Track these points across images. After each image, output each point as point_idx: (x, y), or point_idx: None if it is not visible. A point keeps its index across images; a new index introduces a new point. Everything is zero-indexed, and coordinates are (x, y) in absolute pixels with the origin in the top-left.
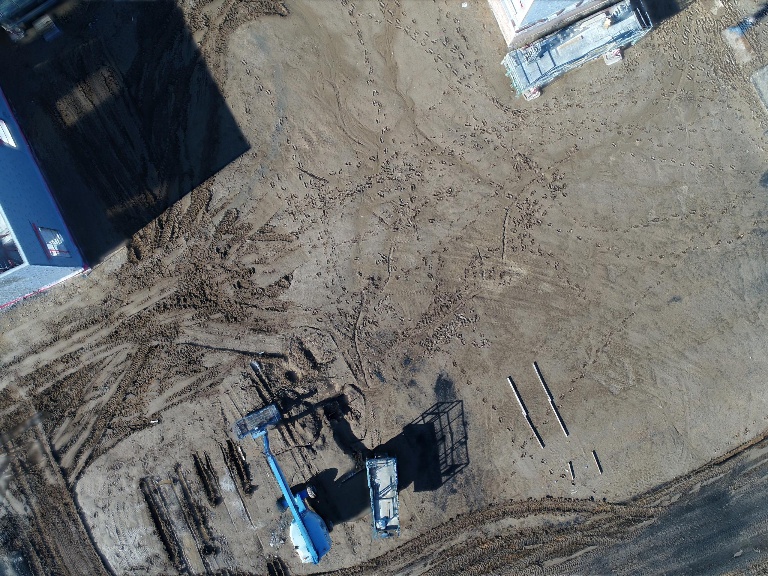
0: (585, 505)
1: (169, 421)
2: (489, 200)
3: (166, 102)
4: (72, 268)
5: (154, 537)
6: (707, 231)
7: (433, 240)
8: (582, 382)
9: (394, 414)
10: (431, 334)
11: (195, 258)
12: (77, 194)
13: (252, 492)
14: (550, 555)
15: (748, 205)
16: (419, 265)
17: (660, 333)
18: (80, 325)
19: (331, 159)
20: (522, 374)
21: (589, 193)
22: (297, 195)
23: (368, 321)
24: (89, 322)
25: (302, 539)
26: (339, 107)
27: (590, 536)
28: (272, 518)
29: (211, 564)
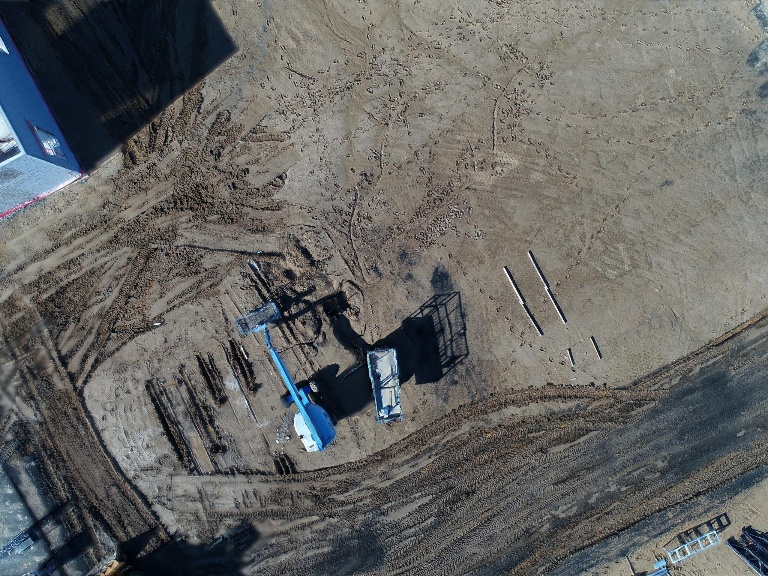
0: (586, 391)
1: (171, 323)
2: (477, 92)
3: (154, 8)
4: (69, 171)
5: (162, 438)
6: (696, 113)
7: (423, 134)
8: (578, 269)
9: (392, 308)
10: (426, 227)
11: (190, 161)
12: (71, 103)
13: (256, 390)
14: (553, 442)
15: (736, 85)
16: (411, 159)
17: (653, 217)
18: (80, 232)
19: (319, 58)
20: (518, 263)
21: (577, 80)
22: (287, 95)
23: (363, 217)
24: (89, 228)
25: (306, 428)
26: (325, 6)
27: (592, 421)
28: (277, 415)
29: (219, 463)
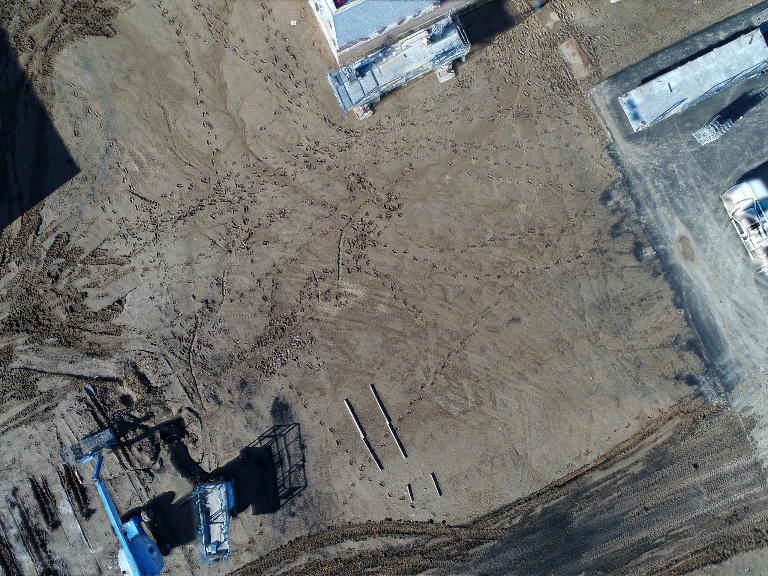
0: (424, 527)
1: (5, 445)
2: (323, 221)
3: None
4: None
5: None
6: (546, 250)
7: (267, 262)
8: (420, 404)
9: (231, 437)
10: (267, 357)
11: (27, 283)
12: None
13: (89, 516)
14: None
15: (588, 223)
16: (253, 287)
17: (499, 354)
18: None
19: (162, 181)
20: (359, 396)
21: (425, 213)
22: (129, 218)
23: (203, 344)
24: None
25: (129, 564)
26: (169, 129)
27: (430, 558)
28: (110, 541)
29: None
